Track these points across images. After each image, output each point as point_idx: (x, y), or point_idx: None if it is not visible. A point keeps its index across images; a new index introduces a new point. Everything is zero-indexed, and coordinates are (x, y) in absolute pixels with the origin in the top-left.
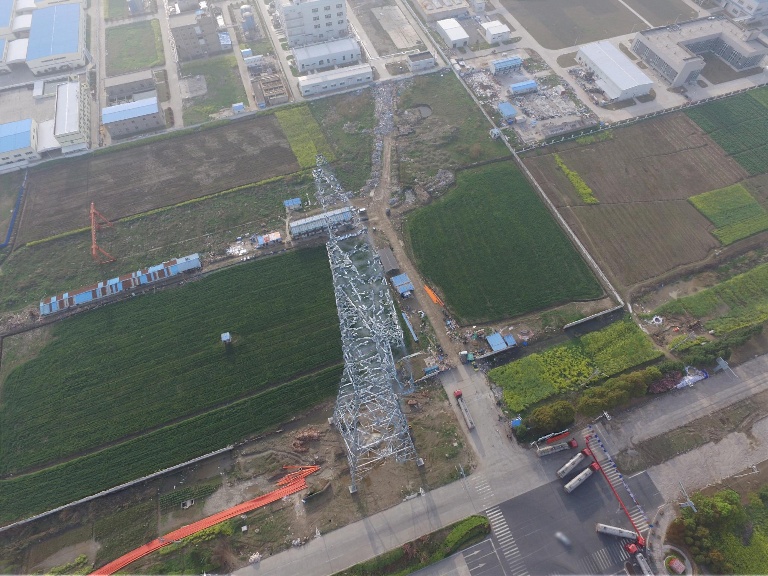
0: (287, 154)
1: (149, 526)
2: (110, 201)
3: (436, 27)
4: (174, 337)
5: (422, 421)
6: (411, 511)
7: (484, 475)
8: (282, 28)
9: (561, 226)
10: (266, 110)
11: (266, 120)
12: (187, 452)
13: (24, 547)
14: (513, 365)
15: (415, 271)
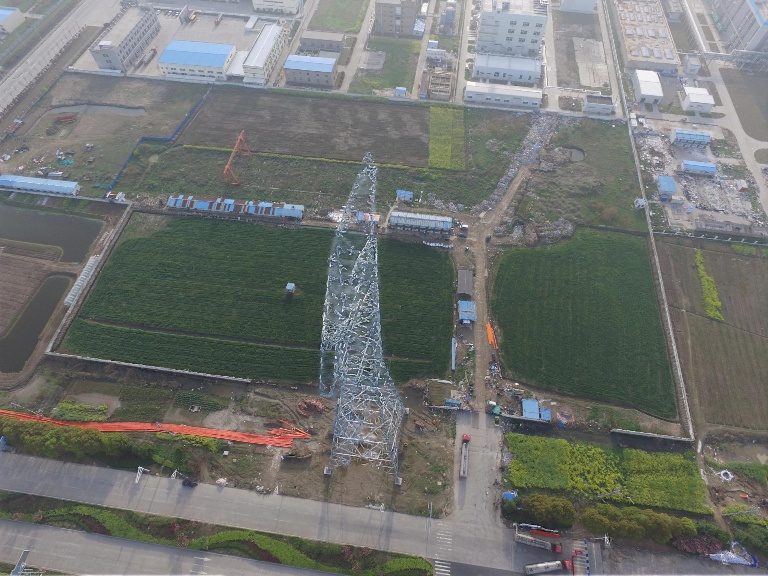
0: (423, 148)
1: (160, 410)
2: (259, 134)
3: (632, 75)
4: (252, 268)
5: (420, 445)
6: (368, 520)
7: (452, 527)
8: (476, 31)
9: (664, 327)
10: (424, 102)
11: (420, 111)
12: (215, 367)
13: (72, 377)
14: (536, 440)
15: (486, 304)
